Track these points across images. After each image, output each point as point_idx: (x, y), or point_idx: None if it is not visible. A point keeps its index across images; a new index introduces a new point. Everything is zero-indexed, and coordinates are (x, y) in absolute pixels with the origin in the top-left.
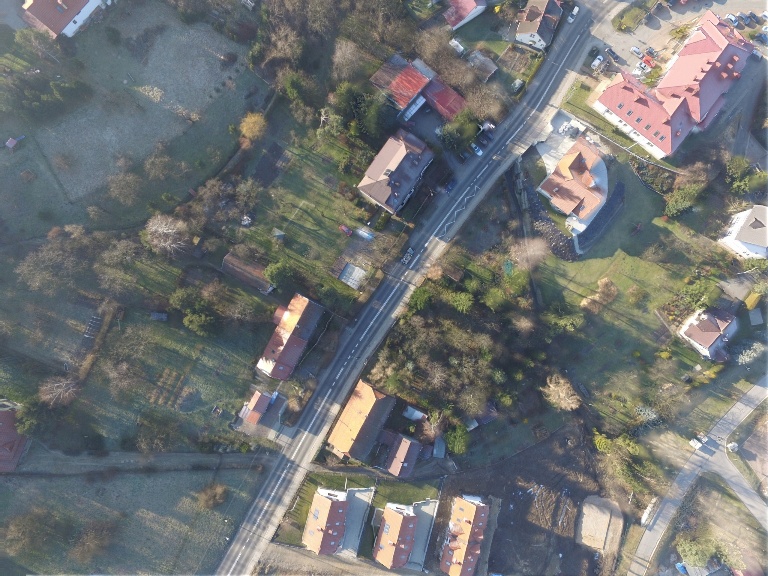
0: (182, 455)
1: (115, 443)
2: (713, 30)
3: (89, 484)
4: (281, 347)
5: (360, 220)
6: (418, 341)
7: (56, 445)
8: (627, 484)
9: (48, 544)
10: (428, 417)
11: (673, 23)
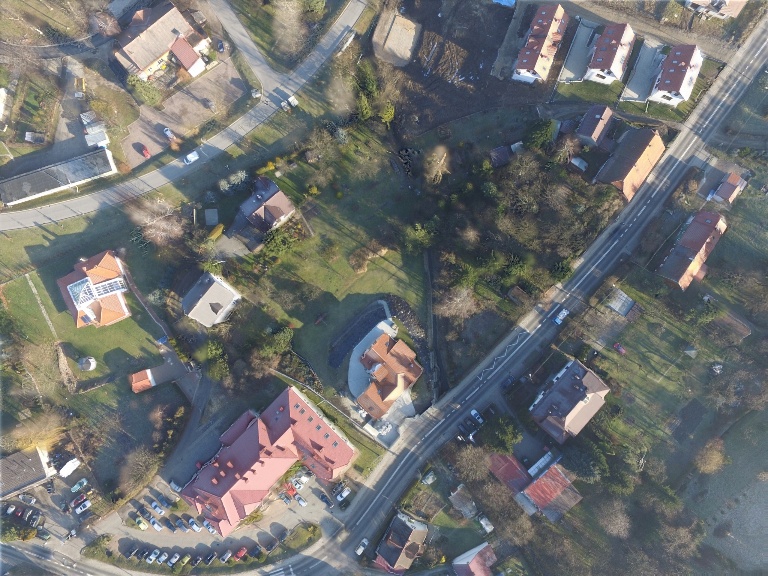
0: None
1: None
2: (231, 514)
3: None
4: (708, 241)
5: (604, 357)
6: (572, 232)
7: None
8: None
9: None
10: None
11: (257, 528)
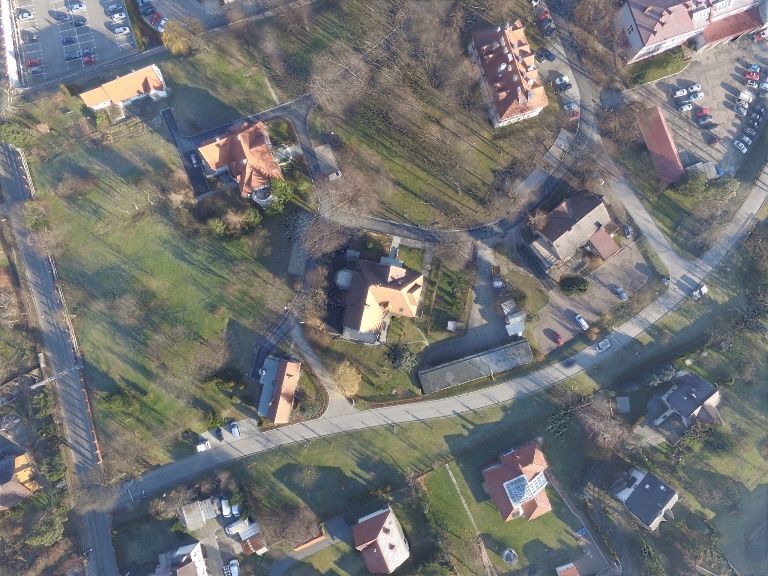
0: None
1: None
2: None
3: None
4: None
5: None
6: None
7: None
8: None
9: None
10: None
11: None
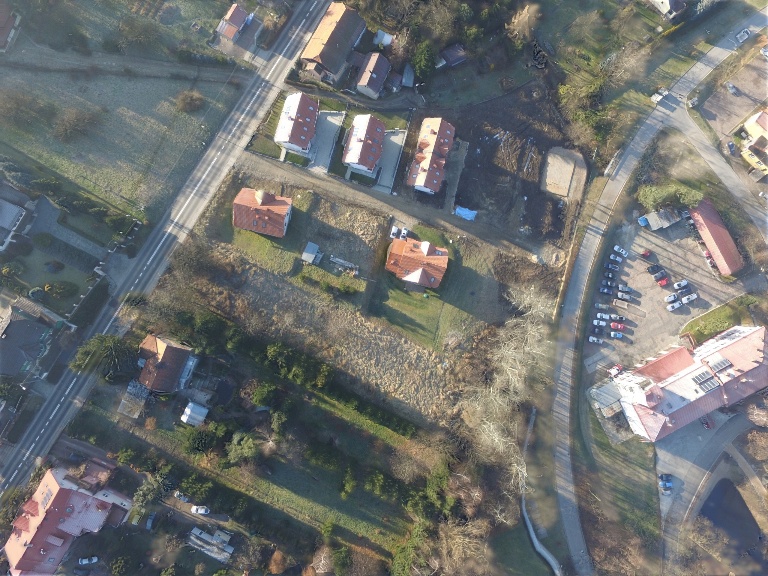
0: (162, 64)
1: (98, 45)
2: None
3: (73, 81)
4: None
5: None
6: None
7: (42, 38)
8: (590, 134)
9: (32, 126)
10: (396, 36)
11: None
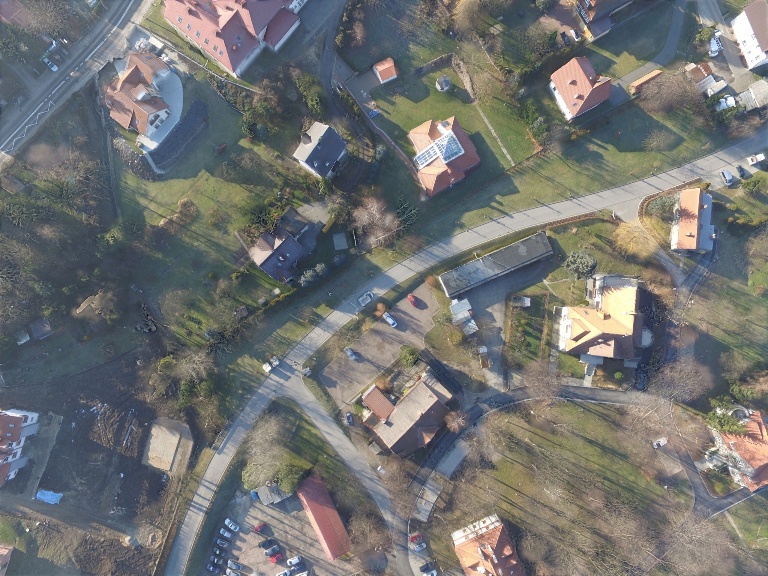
0: None
1: None
2: None
3: None
4: None
5: None
6: None
7: None
8: None
9: None
10: None
11: None
